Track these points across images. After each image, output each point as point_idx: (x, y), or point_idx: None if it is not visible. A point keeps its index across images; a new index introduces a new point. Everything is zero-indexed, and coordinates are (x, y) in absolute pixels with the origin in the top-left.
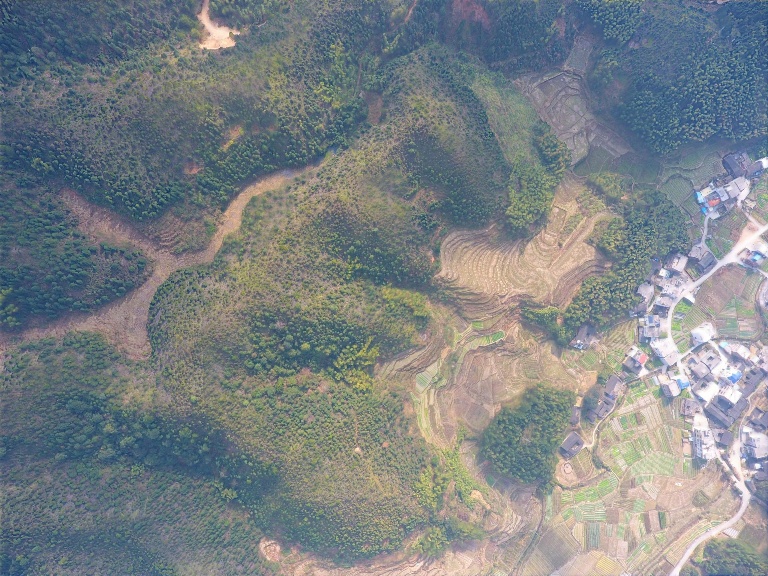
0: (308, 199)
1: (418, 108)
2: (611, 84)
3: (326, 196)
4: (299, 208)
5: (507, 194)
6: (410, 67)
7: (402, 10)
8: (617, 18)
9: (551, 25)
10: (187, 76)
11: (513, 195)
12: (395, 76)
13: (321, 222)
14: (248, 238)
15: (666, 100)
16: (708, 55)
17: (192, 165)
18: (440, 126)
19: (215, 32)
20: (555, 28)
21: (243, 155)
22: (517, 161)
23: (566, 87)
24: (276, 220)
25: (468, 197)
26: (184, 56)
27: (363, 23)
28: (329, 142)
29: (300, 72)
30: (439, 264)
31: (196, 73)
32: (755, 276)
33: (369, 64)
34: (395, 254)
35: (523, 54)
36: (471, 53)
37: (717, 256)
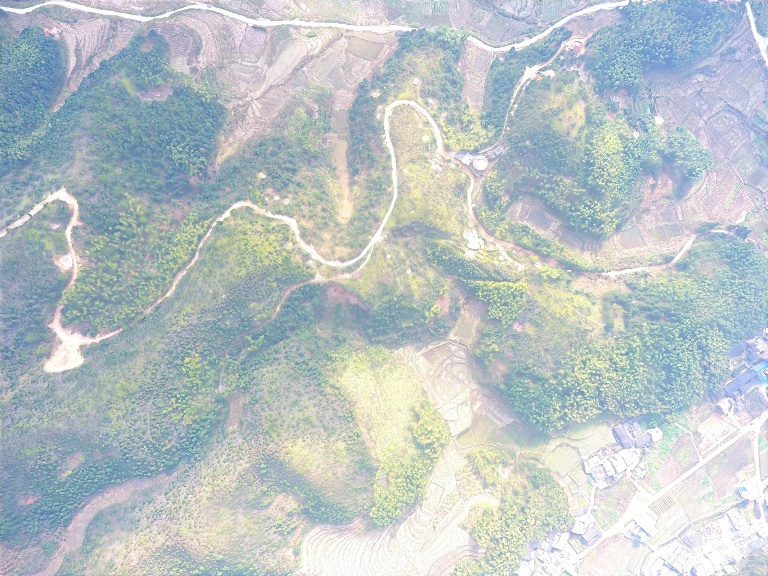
0: (149, 528)
1: (269, 432)
2: (494, 363)
3: (167, 526)
4: (139, 539)
5: (372, 492)
6: (272, 371)
7: (265, 315)
8: (501, 299)
9: (431, 308)
10: (20, 418)
11: (377, 496)
12: (255, 382)
13: (161, 554)
14: (85, 567)
15: (545, 390)
16: (588, 351)
17: (28, 496)
18: (293, 448)
19: (67, 340)
20: (436, 310)
21: (85, 479)
22: (385, 458)
23: (452, 355)
24: (114, 551)
25: (326, 506)
26: (22, 388)
27: (223, 329)
28: (182, 453)
29: (148, 394)
30: (299, 563)
31: (30, 413)
32: (641, 548)
33: (230, 366)
34: (247, 567)
35: (404, 330)
36: (350, 328)
37: (603, 527)
